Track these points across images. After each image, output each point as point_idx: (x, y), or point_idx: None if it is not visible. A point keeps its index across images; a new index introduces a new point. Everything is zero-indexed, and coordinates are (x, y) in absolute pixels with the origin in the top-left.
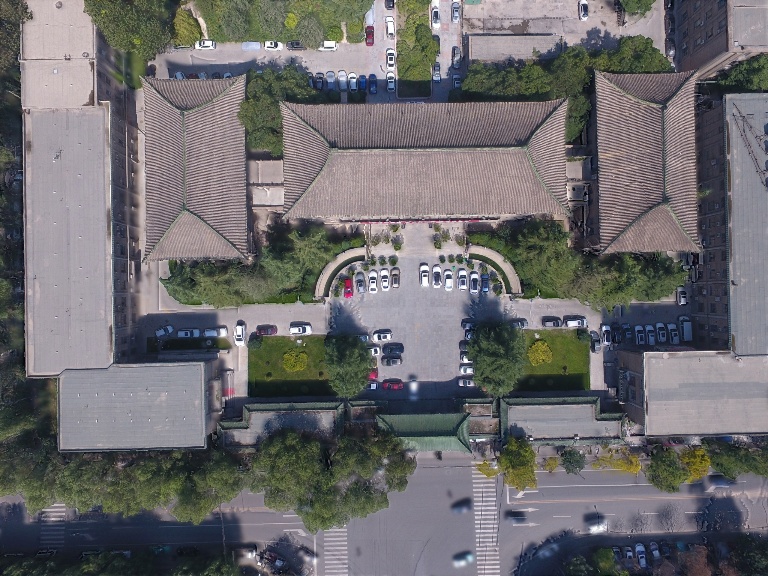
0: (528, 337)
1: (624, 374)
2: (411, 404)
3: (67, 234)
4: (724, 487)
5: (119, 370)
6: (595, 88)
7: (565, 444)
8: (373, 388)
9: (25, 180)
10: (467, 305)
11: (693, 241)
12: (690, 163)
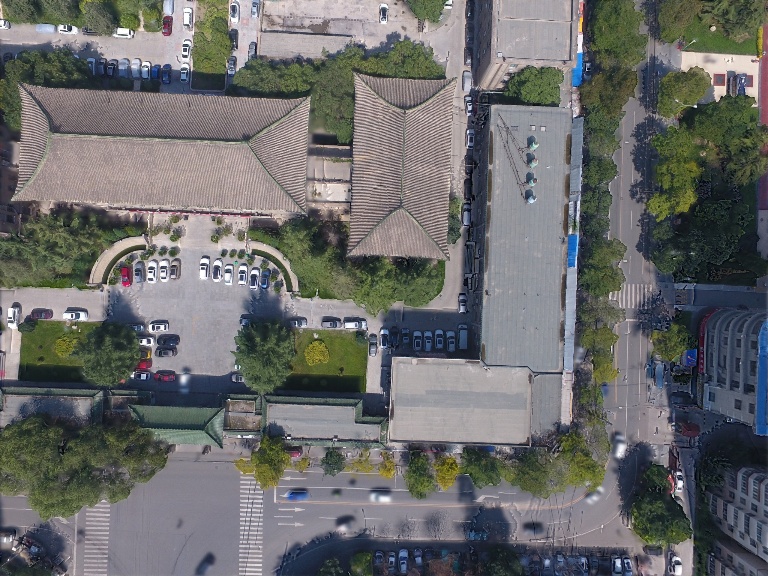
0: (307, 336)
1: (389, 378)
2: (183, 397)
3: None
4: (494, 497)
5: None
6: None
7: (324, 445)
8: (143, 378)
9: None
10: (247, 301)
11: (439, 248)
12: (443, 170)
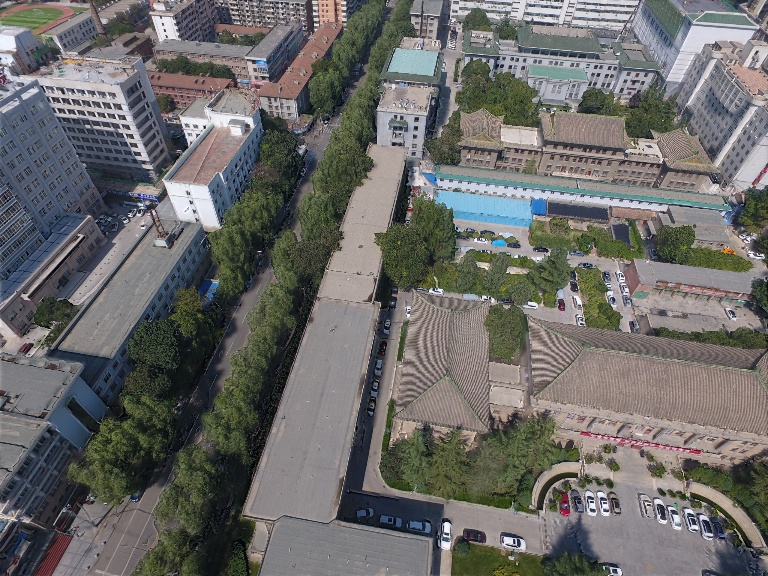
0: None
1: None
2: None
3: (323, 387)
4: None
5: (340, 529)
6: None
7: None
8: None
9: (301, 342)
10: (702, 553)
11: None
12: None
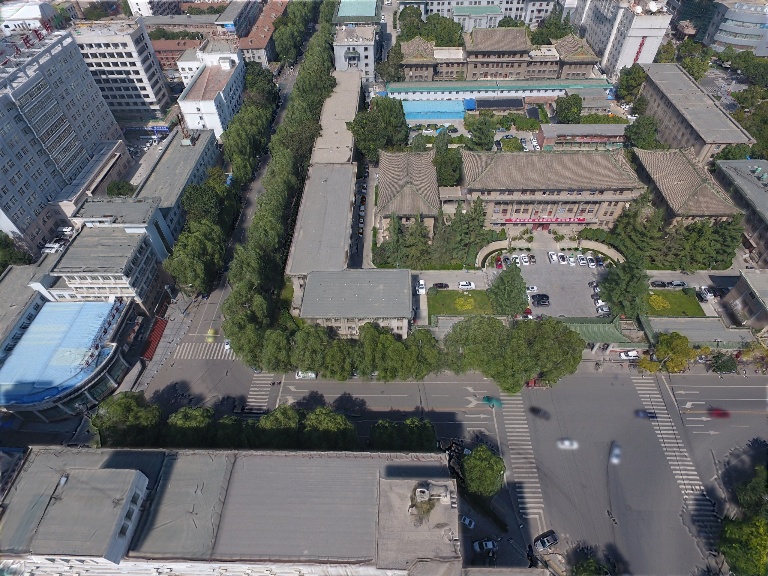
0: None
1: (734, 303)
2: None
3: (325, 210)
4: None
5: (350, 272)
6: (636, 154)
7: (710, 347)
8: None
9: (304, 189)
10: (589, 275)
11: (736, 207)
12: (711, 178)
